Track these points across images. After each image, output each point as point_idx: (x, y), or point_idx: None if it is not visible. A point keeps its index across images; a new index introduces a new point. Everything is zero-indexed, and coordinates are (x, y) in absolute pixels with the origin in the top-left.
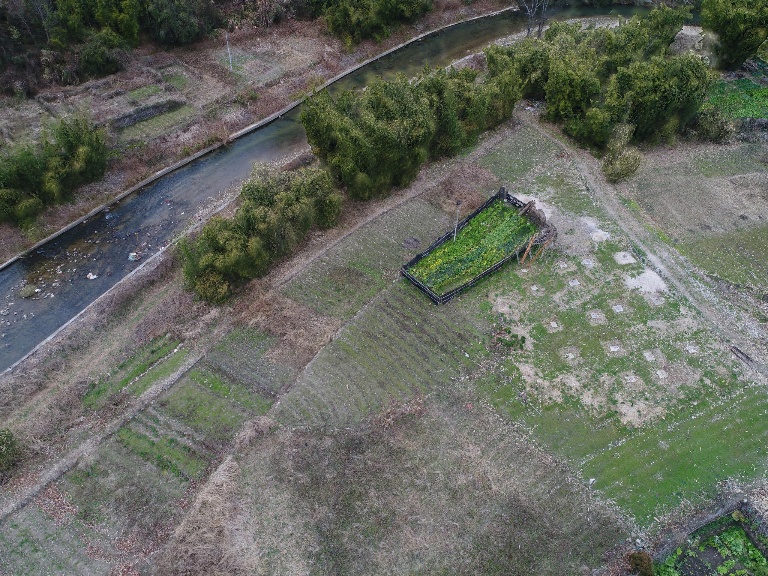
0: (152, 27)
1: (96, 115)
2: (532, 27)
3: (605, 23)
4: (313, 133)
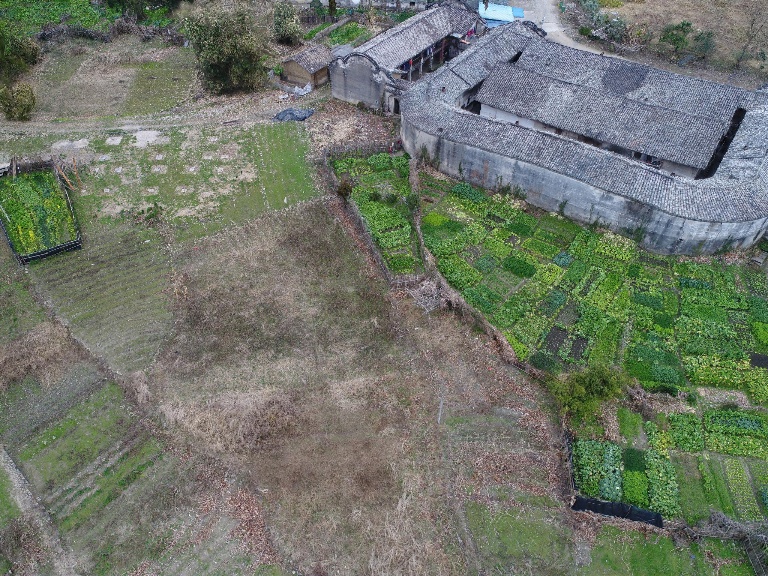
0: None
1: None
2: None
3: None
4: None
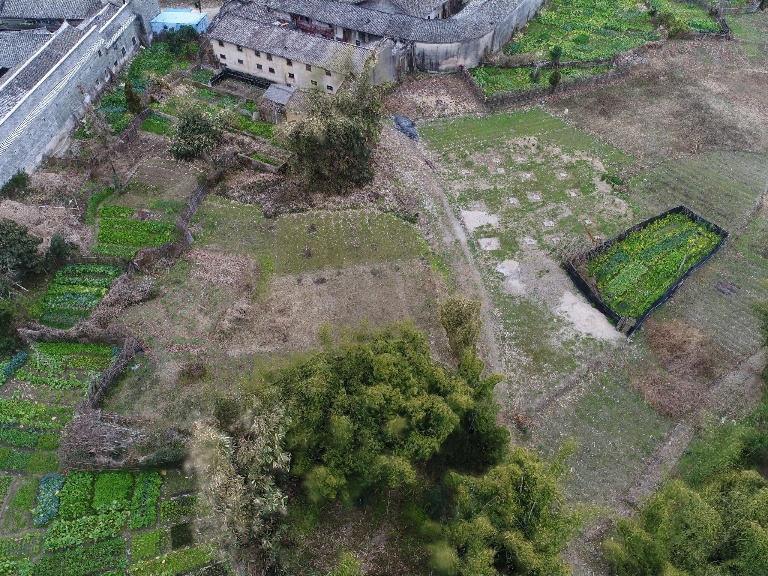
0: None
1: None
2: None
3: None
4: None
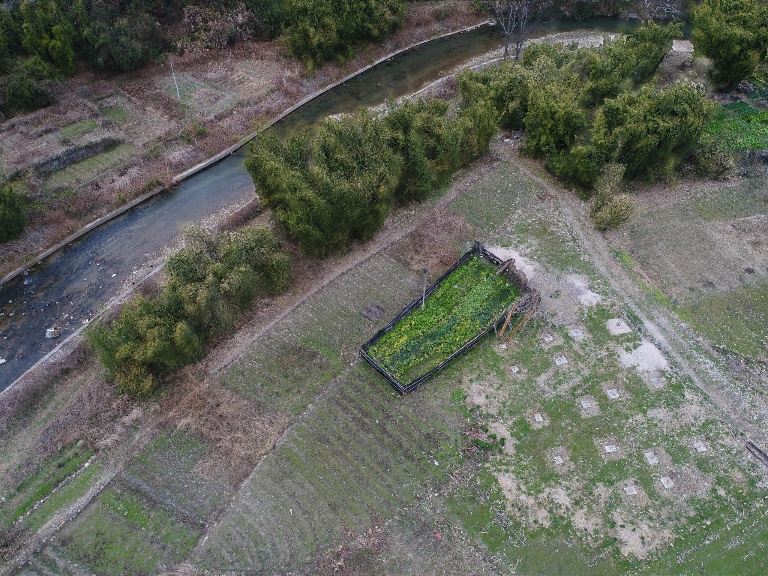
0: (89, 53)
1: (21, 157)
2: (510, 43)
3: (588, 38)
4: (260, 183)
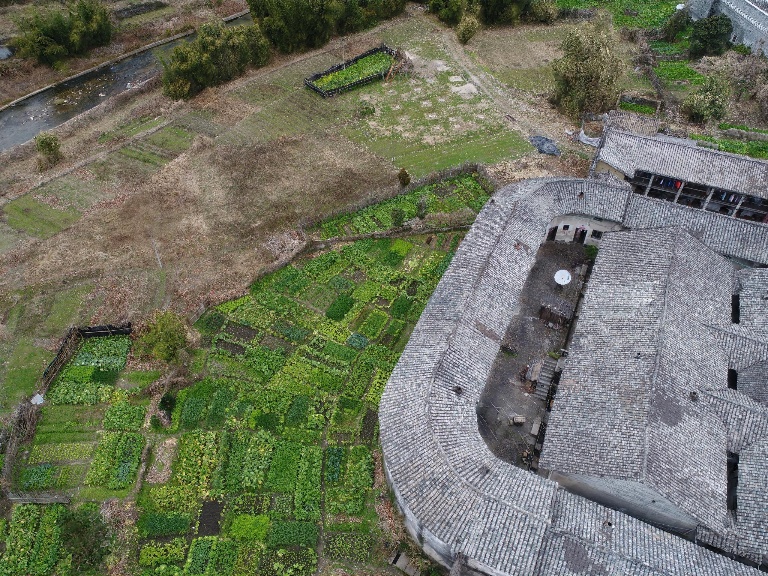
0: None
1: None
2: None
3: None
4: (253, 7)
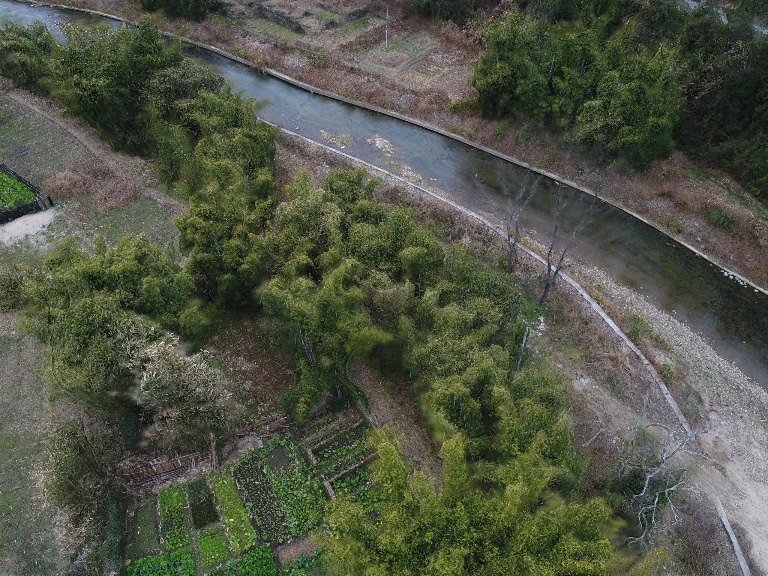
0: None
1: (285, 5)
2: (693, 328)
3: None
4: None
